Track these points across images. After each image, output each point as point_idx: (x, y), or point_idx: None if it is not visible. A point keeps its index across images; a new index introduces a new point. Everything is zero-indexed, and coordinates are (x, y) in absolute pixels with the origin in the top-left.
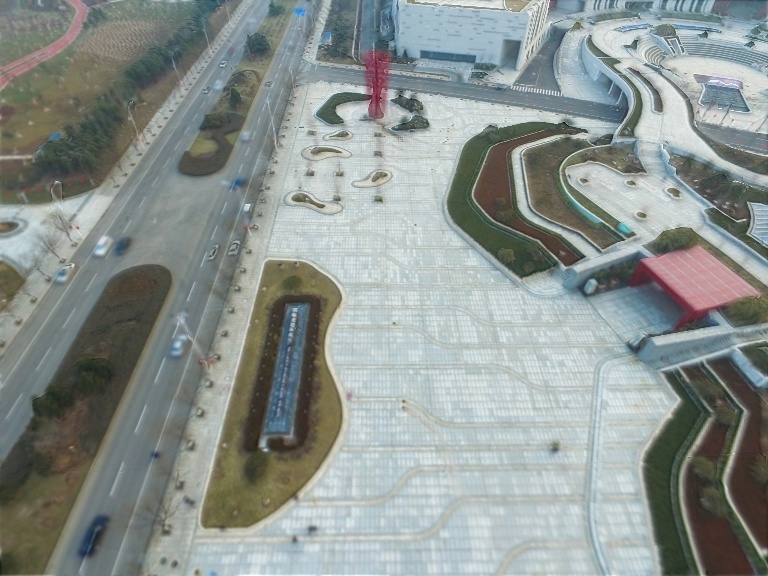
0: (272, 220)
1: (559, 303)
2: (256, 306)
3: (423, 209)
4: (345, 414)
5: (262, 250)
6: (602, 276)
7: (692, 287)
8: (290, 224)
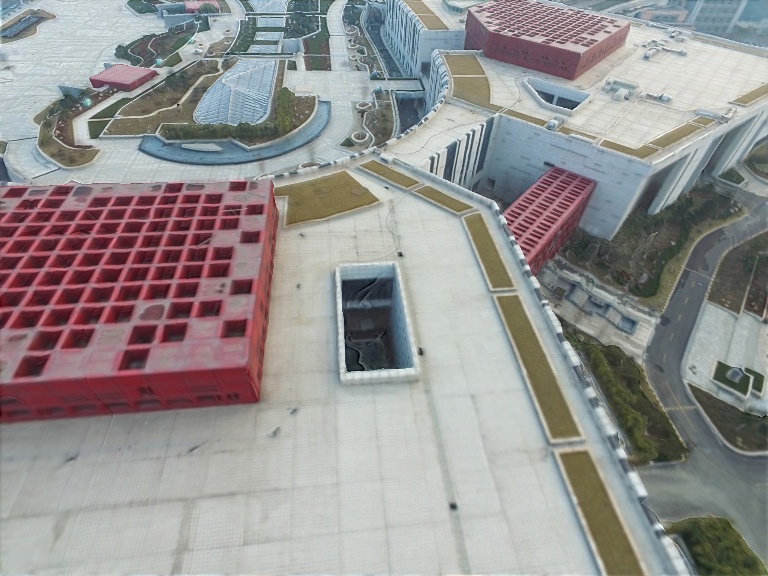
0: (37, 2)
1: (151, 20)
2: (15, 18)
3: (117, 2)
4: (36, 34)
5: (26, 8)
6: (171, 10)
7: (194, 5)
8: (45, 3)
